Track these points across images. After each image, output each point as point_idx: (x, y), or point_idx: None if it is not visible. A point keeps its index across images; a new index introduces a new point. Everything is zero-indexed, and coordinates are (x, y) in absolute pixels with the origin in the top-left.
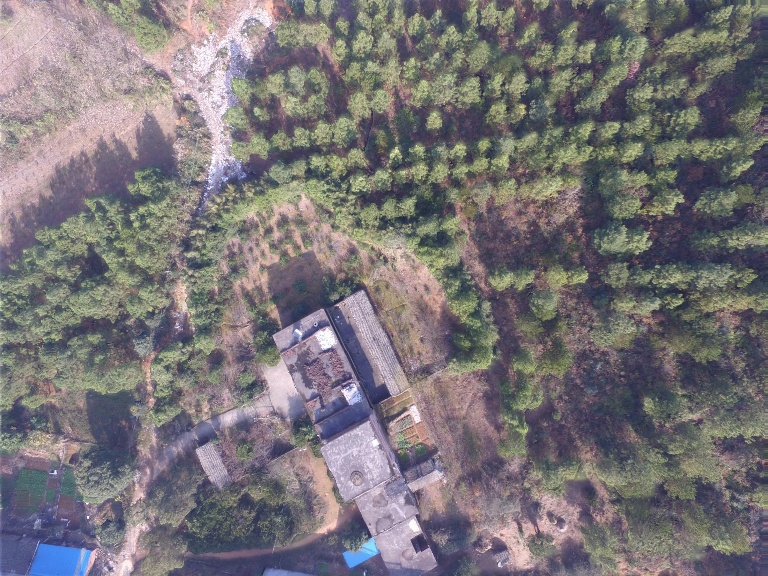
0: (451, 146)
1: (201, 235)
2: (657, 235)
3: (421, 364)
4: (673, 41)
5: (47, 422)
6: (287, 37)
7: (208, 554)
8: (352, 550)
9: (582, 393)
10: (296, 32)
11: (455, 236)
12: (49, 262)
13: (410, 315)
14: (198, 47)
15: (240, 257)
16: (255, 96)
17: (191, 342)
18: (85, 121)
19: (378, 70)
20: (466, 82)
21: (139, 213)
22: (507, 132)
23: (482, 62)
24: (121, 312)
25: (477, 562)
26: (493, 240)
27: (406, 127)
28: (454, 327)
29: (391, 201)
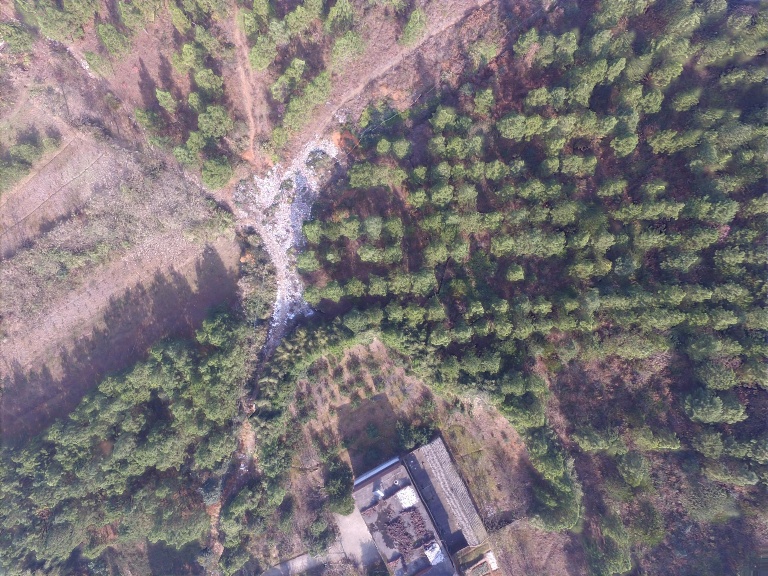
0: (533, 299)
1: (272, 383)
2: (753, 409)
3: (499, 512)
4: (761, 202)
5: (105, 566)
6: (361, 180)
7: None
8: None
9: (669, 554)
10: (370, 174)
11: (541, 396)
12: (112, 413)
13: (486, 461)
14: (261, 178)
15: (309, 399)
16: (326, 237)
17: (258, 486)
18: (141, 251)
19: (459, 221)
20: (553, 240)
21: (209, 365)
22: (588, 281)
23: (568, 219)
24: (185, 457)
25: None
26: (575, 392)
27: (483, 271)
28: (534, 478)
29: (476, 360)
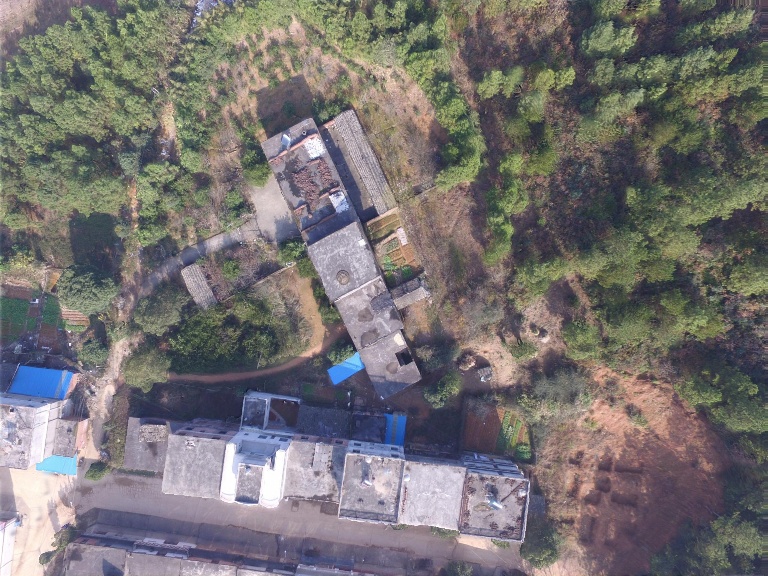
0: None
1: (190, 50)
2: (643, 28)
3: (409, 185)
4: None
5: (29, 250)
6: None
7: (192, 378)
8: (337, 359)
9: (567, 199)
10: None
11: (445, 42)
12: (33, 73)
13: (399, 137)
14: None
15: (229, 81)
16: None
17: (178, 166)
18: None
19: None
20: None
21: (126, 21)
22: None
23: None
24: (107, 134)
25: (460, 381)
26: (483, 56)
27: None
28: (442, 144)
29: (382, 5)
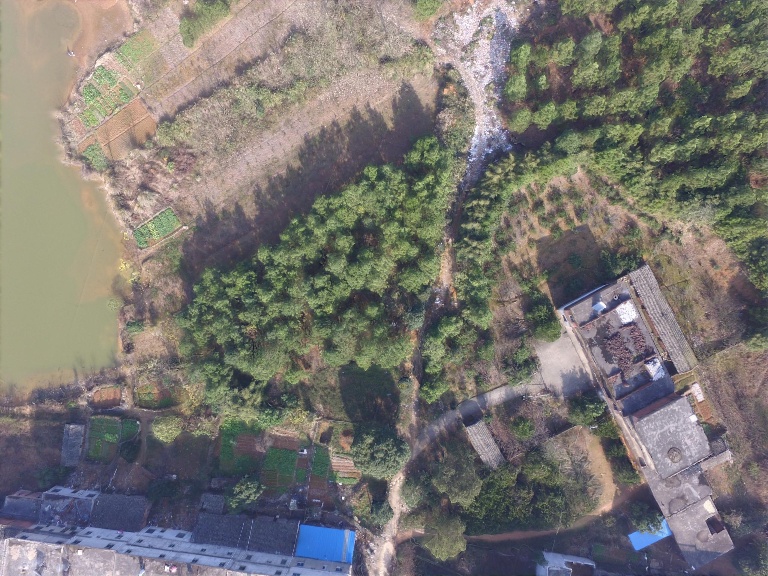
0: None
1: (481, 206)
2: None
3: (708, 341)
4: None
5: (298, 399)
6: (575, 4)
7: (475, 536)
8: (652, 531)
9: None
10: None
11: None
12: (324, 232)
13: (694, 291)
14: (461, 15)
15: (509, 230)
16: (534, 64)
17: (457, 317)
18: (337, 90)
19: (681, 37)
20: None
21: (425, 182)
22: None
23: None
24: None
25: None
26: None
27: (693, 98)
28: (748, 302)
29: (704, 170)
